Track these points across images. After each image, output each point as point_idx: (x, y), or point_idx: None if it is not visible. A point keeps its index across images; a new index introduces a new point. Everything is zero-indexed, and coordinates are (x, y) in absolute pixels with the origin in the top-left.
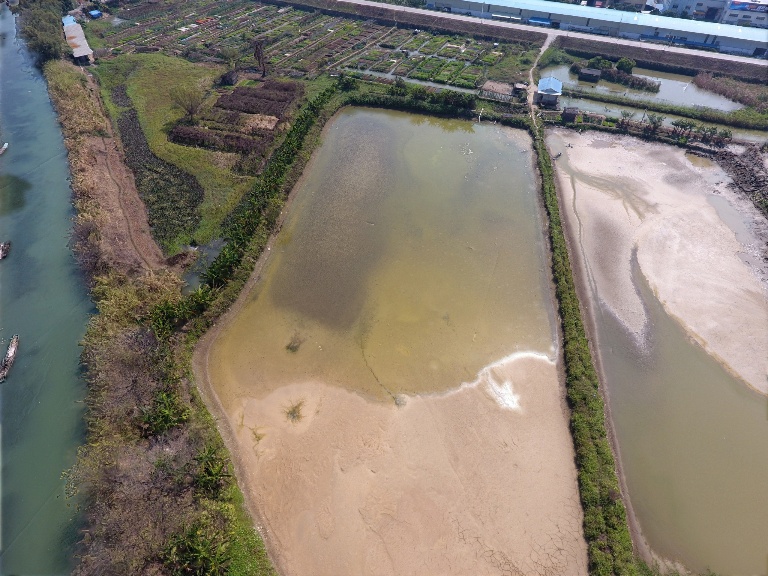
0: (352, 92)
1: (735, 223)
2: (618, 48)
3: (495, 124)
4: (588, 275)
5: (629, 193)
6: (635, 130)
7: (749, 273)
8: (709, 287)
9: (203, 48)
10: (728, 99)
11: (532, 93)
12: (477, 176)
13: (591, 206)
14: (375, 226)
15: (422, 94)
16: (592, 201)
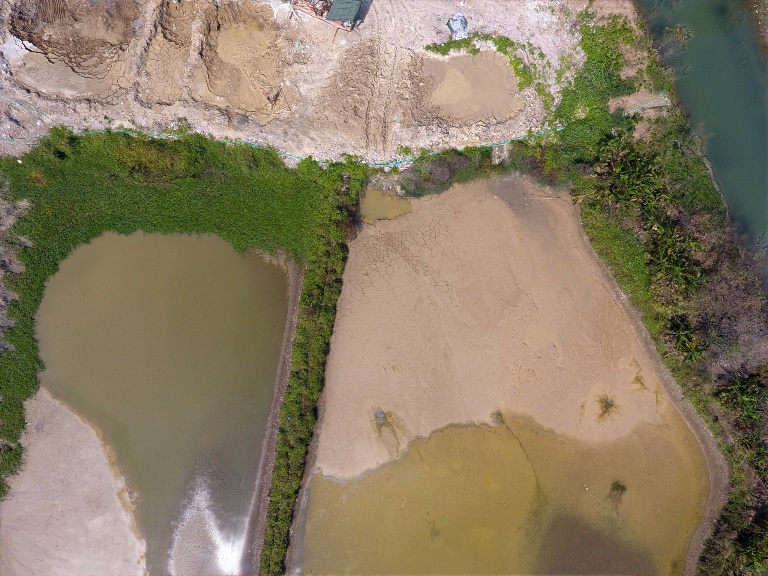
0: None
1: None
2: None
3: None
4: None
5: None
6: None
7: None
8: None
9: None
10: None
11: None
12: None
13: None
14: None
15: None
16: None
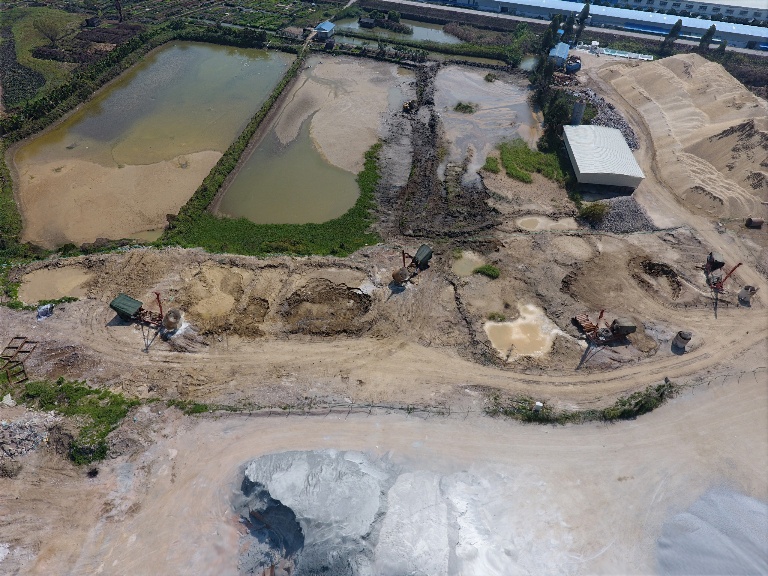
0: (180, 30)
1: (394, 100)
2: (399, 6)
3: (277, 51)
4: (276, 121)
5: (339, 86)
6: (371, 54)
7: (378, 121)
8: (346, 126)
9: (82, 4)
10: (458, 38)
11: (315, 33)
12: (242, 77)
13: (307, 92)
14: (155, 100)
15: (228, 31)
16: (310, 90)
